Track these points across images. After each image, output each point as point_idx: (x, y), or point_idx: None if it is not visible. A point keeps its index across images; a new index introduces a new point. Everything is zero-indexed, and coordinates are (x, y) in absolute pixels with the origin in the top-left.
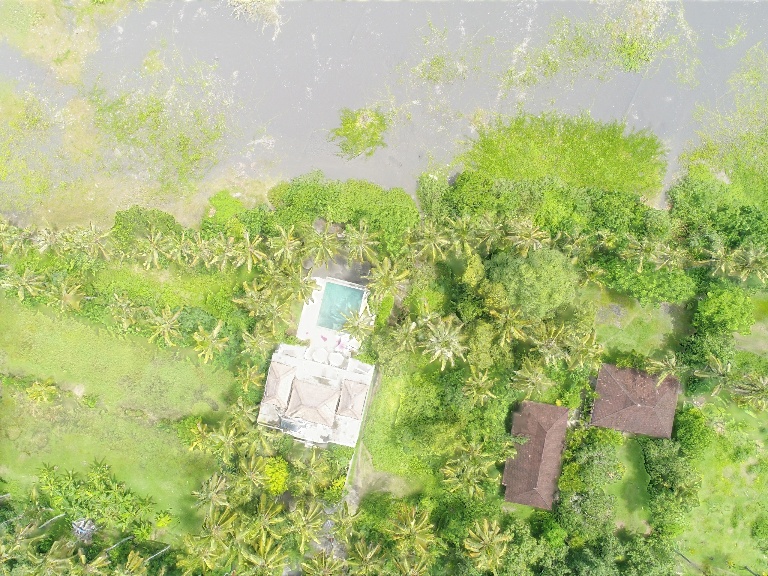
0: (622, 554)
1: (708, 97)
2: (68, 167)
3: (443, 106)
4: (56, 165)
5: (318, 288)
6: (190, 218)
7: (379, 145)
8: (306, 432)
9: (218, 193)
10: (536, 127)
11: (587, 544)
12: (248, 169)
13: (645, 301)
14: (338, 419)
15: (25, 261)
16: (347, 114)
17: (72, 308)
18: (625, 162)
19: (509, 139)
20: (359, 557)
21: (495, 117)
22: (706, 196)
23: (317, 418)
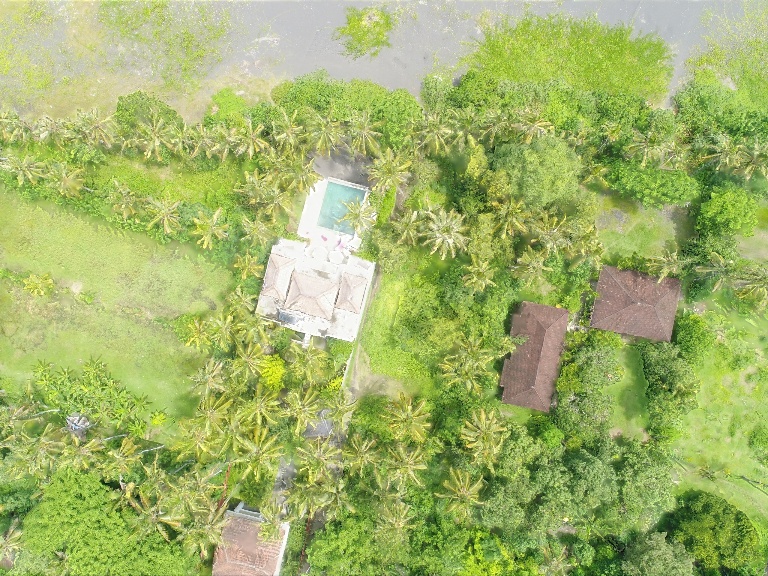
0: (619, 453)
1: (716, 1)
2: (71, 62)
3: (449, 6)
4: (59, 60)
5: (320, 177)
6: (192, 116)
7: (384, 45)
8: (304, 325)
9: (221, 90)
10: (542, 29)
11: (584, 446)
12: (252, 67)
13: (648, 201)
14: (337, 313)
15: (25, 155)
16: (353, 12)
17: (71, 195)
18: (631, 66)
19: (515, 41)
20: (354, 450)
21: (501, 18)
22: (712, 99)
23: (315, 310)
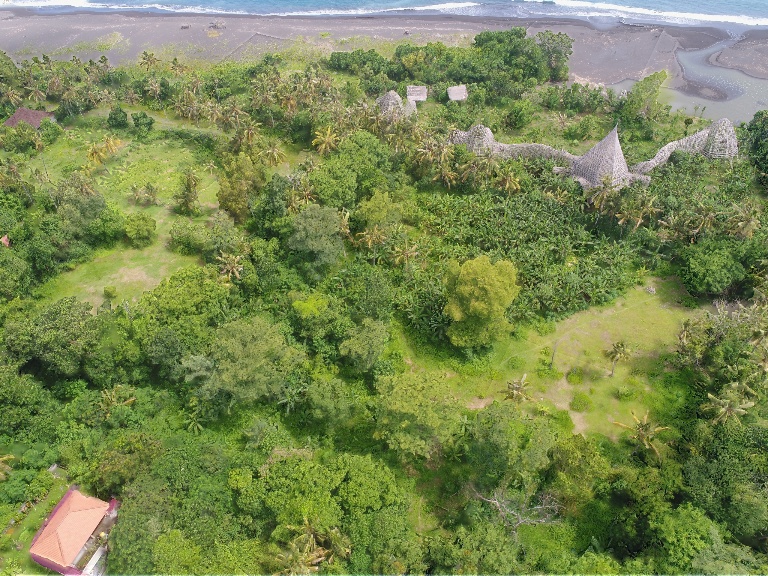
0: None
1: None
2: None
3: None
4: None
5: None
6: None
7: None
8: None
9: None
10: None
11: None
12: None
13: None
14: None
15: None
16: None
17: None
18: None
19: None
20: None
21: None
22: None
23: None
